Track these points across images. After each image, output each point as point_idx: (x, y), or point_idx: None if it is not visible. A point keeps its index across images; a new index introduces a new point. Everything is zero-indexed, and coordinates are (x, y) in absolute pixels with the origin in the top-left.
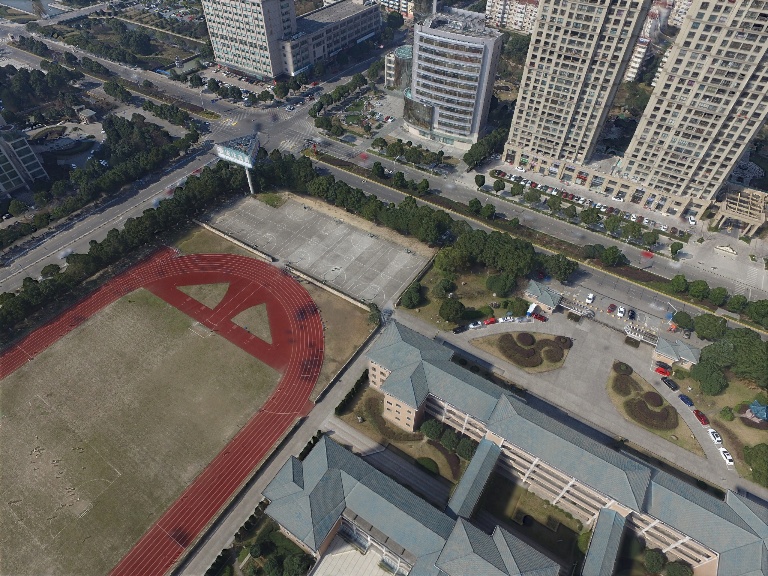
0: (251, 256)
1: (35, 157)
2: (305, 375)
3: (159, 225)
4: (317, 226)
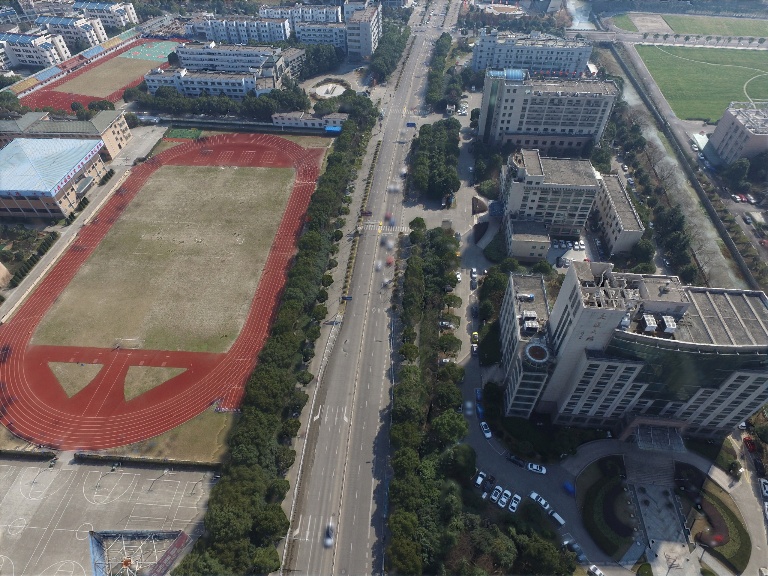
0: (114, 450)
1: (516, 391)
2: (5, 352)
3: (243, 403)
4: (15, 567)
